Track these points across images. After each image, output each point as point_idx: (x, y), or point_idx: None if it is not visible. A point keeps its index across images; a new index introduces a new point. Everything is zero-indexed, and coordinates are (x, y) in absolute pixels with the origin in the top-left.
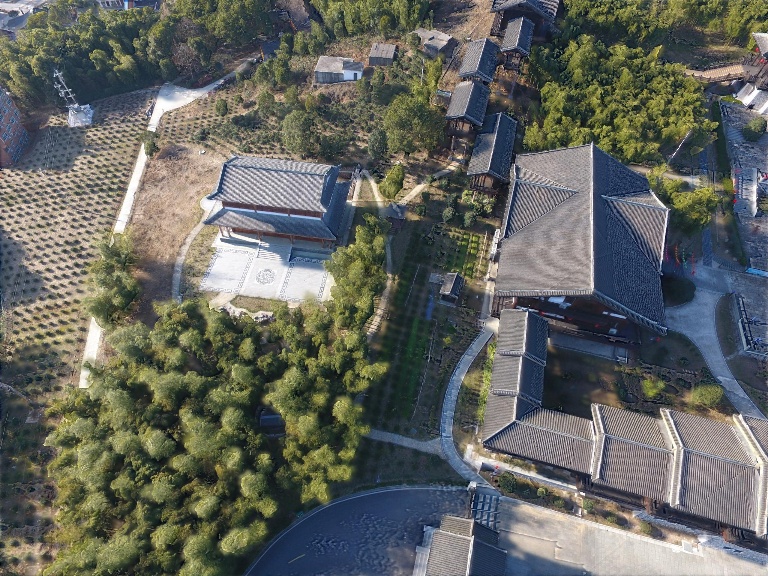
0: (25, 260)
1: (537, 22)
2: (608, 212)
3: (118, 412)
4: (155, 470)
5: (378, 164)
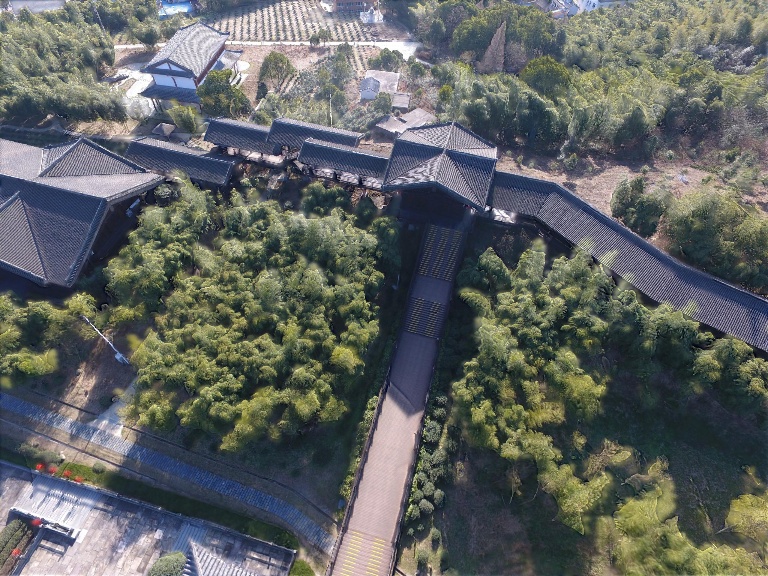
0: None
1: None
2: (0, 197)
3: None
4: (4, 48)
5: None
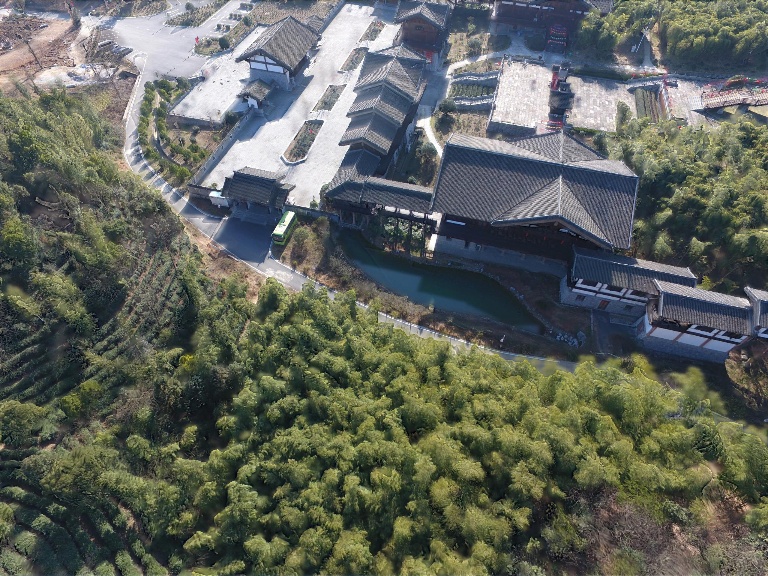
0: None
1: None
2: None
3: None
4: None
5: None
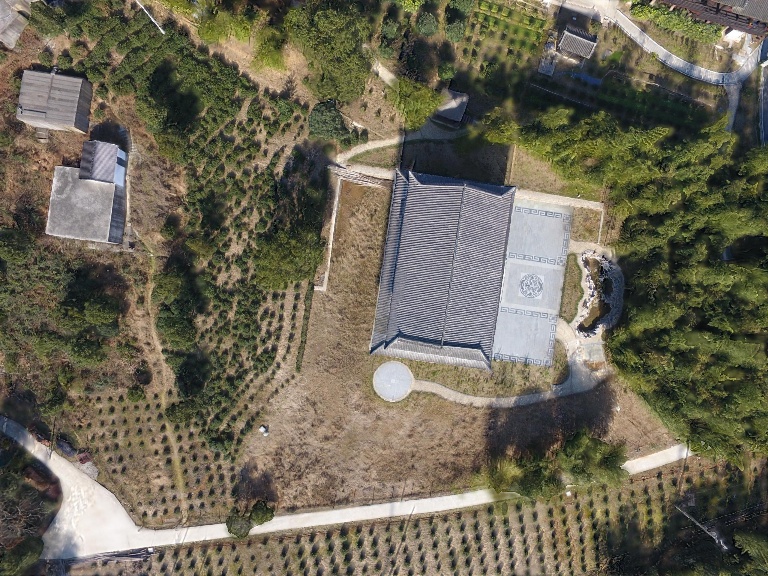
0: None
1: None
2: None
3: None
4: None
5: None
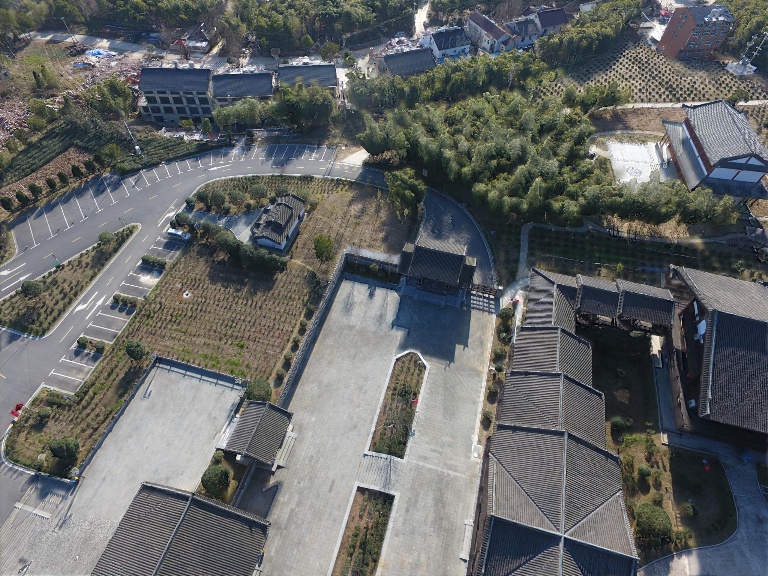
0: (594, 78)
1: None
2: None
3: (507, 109)
4: (479, 128)
5: None
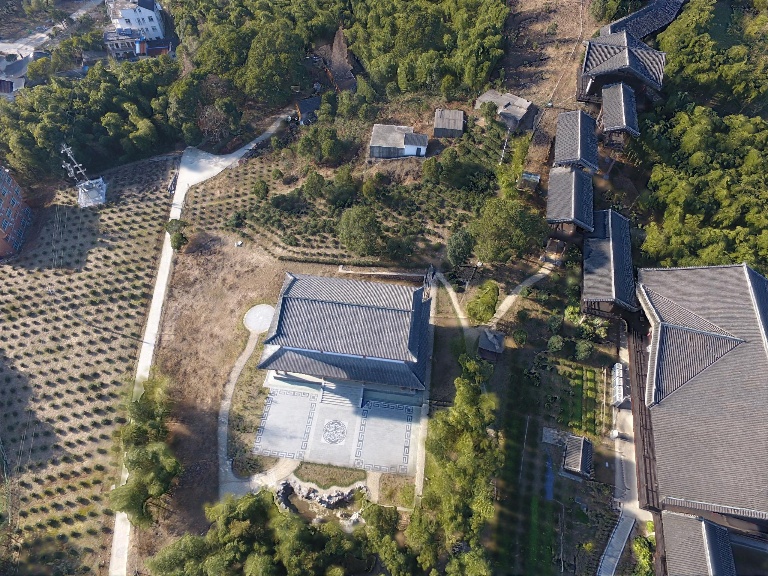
0: (32, 402)
1: (636, 87)
2: None
3: None
4: None
5: (455, 266)
